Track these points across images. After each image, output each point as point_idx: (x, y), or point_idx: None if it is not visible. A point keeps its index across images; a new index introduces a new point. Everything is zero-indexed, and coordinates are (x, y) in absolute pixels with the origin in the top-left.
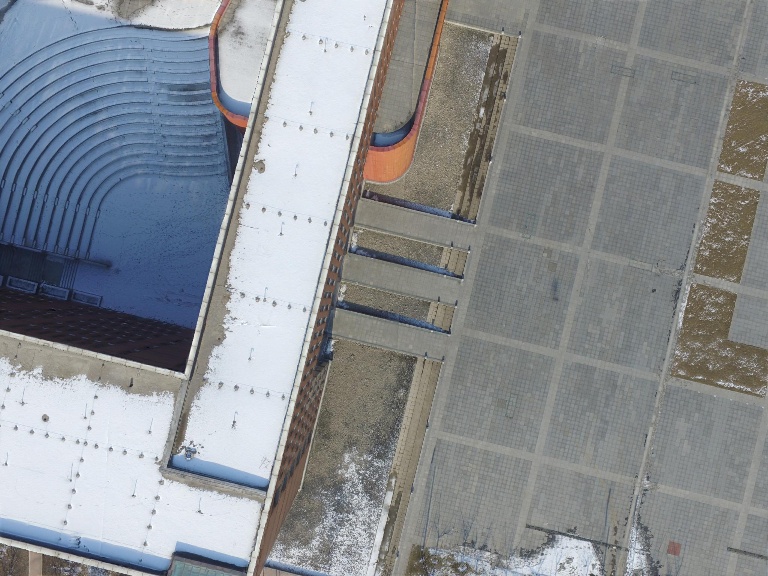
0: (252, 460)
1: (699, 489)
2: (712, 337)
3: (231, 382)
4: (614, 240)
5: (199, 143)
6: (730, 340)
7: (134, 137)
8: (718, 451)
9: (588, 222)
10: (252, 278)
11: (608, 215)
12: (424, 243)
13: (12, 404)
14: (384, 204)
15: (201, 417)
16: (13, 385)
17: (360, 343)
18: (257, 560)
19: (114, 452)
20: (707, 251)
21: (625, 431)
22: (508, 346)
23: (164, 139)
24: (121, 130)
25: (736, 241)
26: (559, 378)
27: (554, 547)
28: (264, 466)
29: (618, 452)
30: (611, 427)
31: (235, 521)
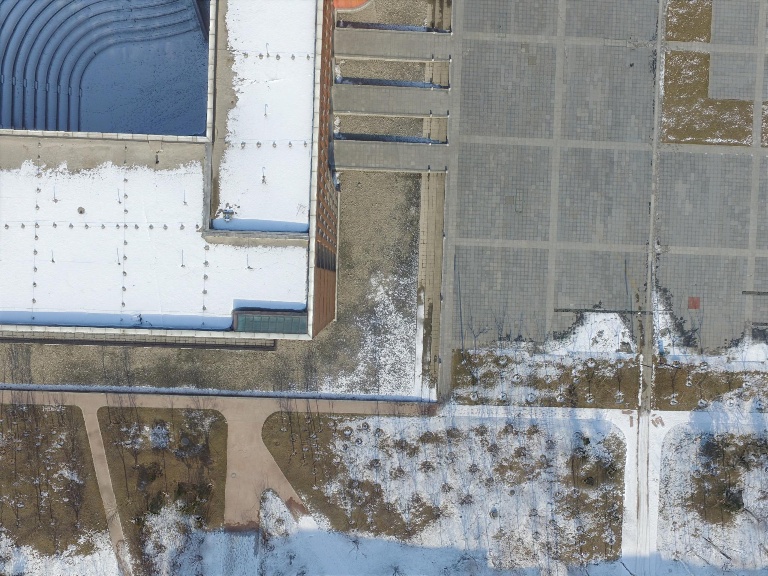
0: (288, 209)
1: (707, 243)
2: (694, 98)
3: (252, 140)
4: (586, 23)
5: (165, 0)
6: (711, 98)
7: (99, 7)
8: (718, 204)
9: (558, 11)
10: (251, 37)
11: (576, 0)
12: (406, 62)
13: (45, 203)
14: (359, 30)
15: (231, 179)
16: (42, 185)
17: (364, 170)
18: (313, 298)
19: (155, 229)
20: (675, 17)
21: (629, 203)
22: (505, 144)
23: (130, 3)
24: (85, 1)
25: (700, 2)
26: (559, 165)
27: (584, 324)
28: (301, 212)
29: (626, 224)
30: (616, 202)
31: (284, 269)
